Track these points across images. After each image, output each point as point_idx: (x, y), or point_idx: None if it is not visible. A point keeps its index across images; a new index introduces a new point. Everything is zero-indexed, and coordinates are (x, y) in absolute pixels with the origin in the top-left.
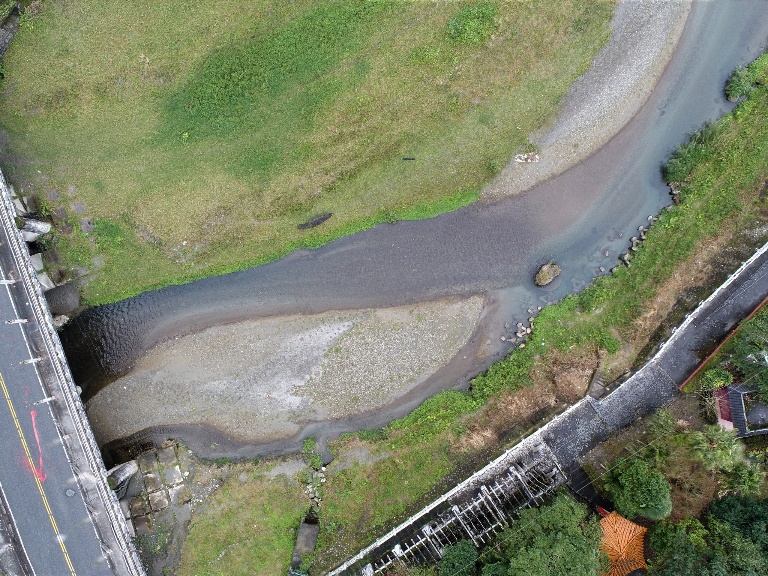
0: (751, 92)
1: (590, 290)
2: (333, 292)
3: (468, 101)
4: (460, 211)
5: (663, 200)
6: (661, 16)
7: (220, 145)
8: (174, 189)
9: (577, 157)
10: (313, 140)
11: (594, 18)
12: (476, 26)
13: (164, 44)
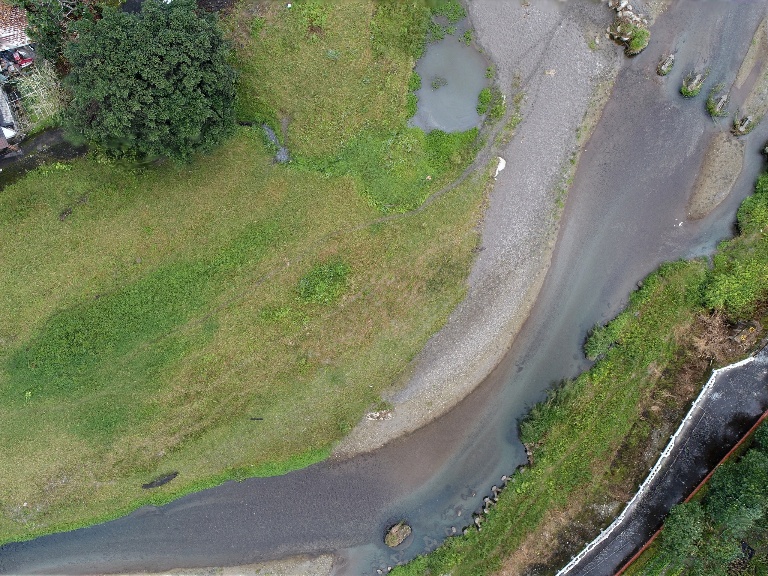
0: (609, 352)
1: (440, 552)
2: (179, 549)
3: (318, 362)
4: (310, 468)
5: (519, 457)
6: (519, 272)
7: (64, 404)
8: (15, 450)
9: (431, 415)
10: (158, 400)
11: (449, 277)
12: (326, 287)
13: (5, 306)
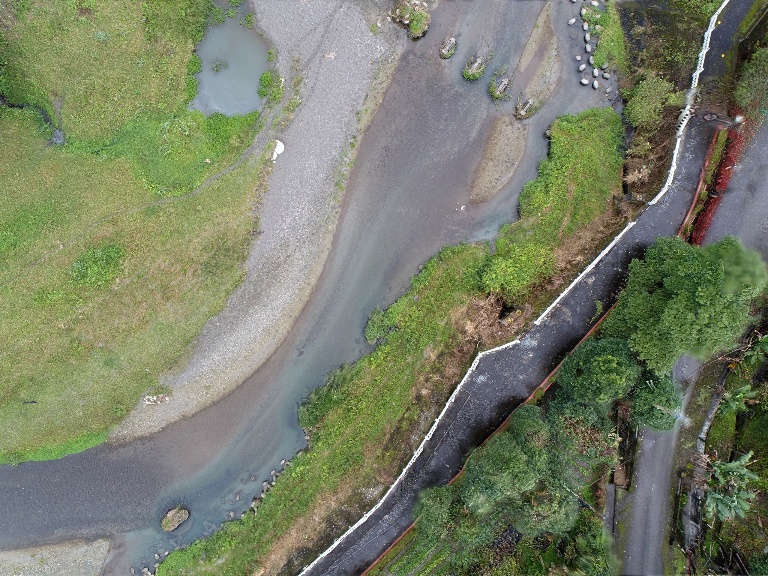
0: (389, 335)
1: (217, 537)
2: None
3: (91, 345)
4: (88, 452)
5: (300, 442)
6: (299, 256)
7: None
8: None
9: (209, 399)
10: None
11: (224, 261)
12: (99, 270)
13: None
